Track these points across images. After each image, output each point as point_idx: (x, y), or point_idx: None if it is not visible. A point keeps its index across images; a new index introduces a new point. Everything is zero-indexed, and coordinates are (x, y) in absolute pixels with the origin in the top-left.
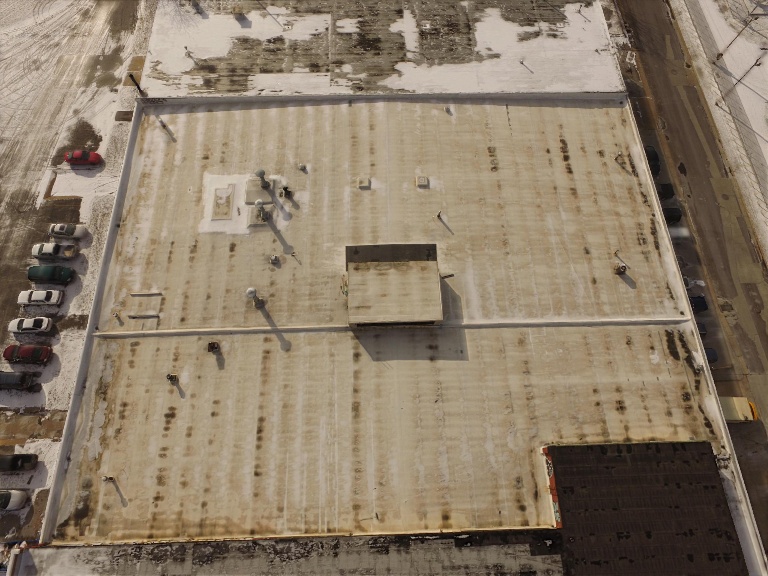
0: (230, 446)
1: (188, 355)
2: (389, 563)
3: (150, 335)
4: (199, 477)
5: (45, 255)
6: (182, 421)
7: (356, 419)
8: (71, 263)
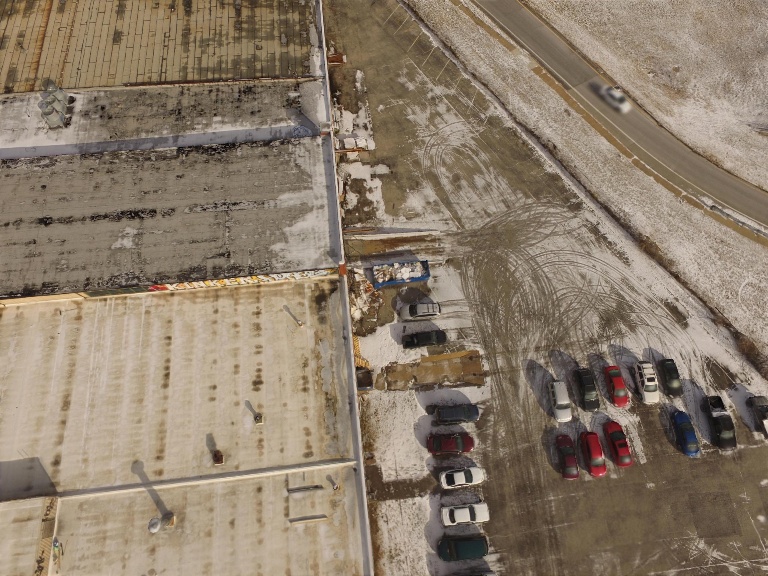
0: (196, 360)
1: (248, 447)
2: (43, 277)
3: (293, 467)
4: (223, 332)
5: (479, 575)
6: (245, 379)
7: (67, 394)
8: (450, 570)
